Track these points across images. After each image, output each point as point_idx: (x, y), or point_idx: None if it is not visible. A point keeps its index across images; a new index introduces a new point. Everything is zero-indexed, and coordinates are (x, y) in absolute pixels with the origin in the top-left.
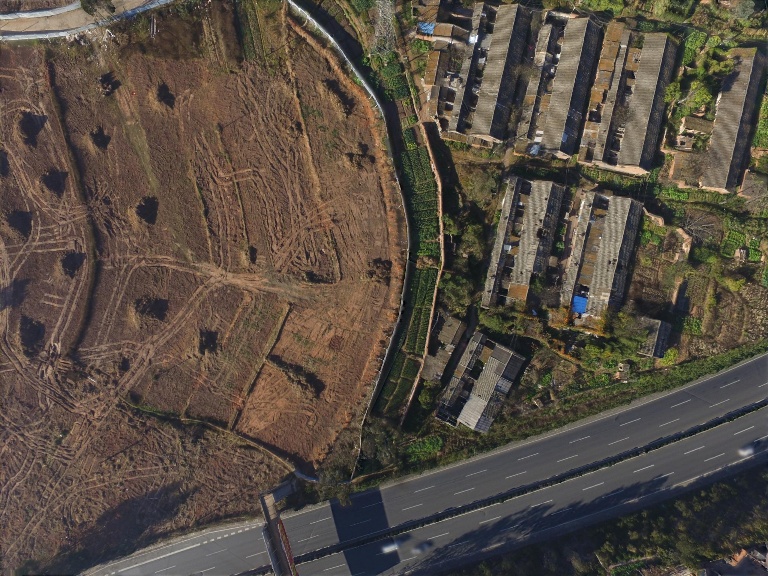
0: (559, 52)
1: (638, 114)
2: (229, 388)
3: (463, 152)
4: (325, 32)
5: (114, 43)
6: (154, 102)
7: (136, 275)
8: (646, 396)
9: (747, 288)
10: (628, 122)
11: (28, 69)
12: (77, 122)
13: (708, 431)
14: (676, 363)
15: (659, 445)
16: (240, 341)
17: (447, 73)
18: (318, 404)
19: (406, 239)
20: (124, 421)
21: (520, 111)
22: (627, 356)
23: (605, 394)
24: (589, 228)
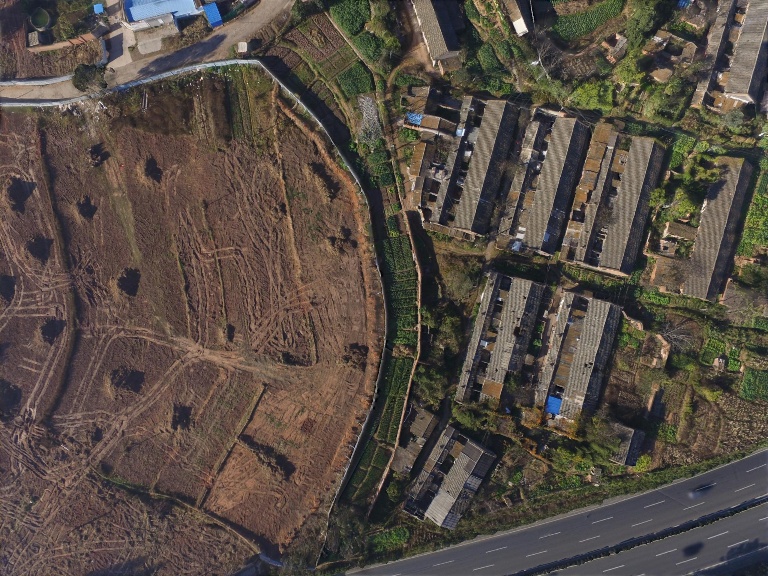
0: (546, 148)
1: (621, 217)
2: (200, 465)
3: (445, 243)
4: (314, 116)
5: (106, 115)
6: (141, 176)
7: (114, 345)
8: (619, 495)
9: (724, 399)
10: (611, 224)
11: (20, 136)
12: (65, 191)
13: (681, 534)
14: (649, 470)
15: (630, 546)
16: (213, 418)
17: (432, 164)
18: (287, 486)
19: (384, 326)
20: (94, 492)
21: (503, 207)
22: (598, 463)
23: (576, 494)
24: (567, 329)
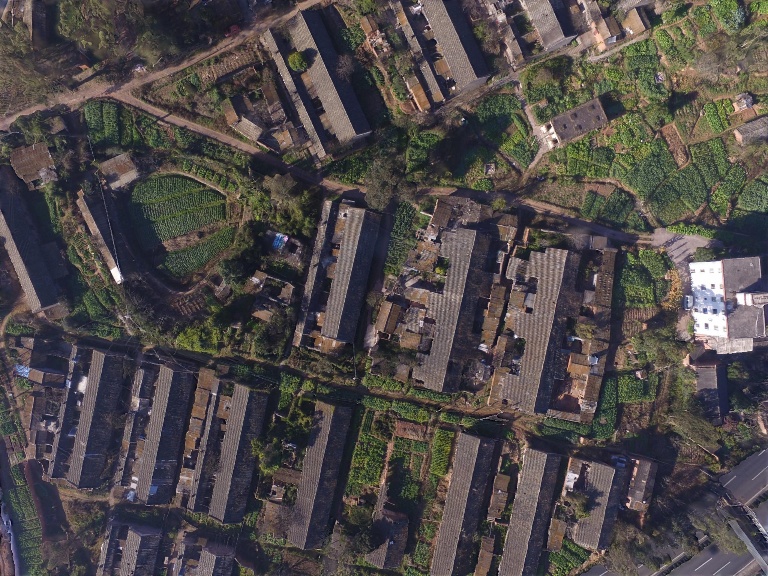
0: None
1: (225, 467)
2: None
3: (70, 490)
4: None
5: None
6: None
7: None
8: None
9: None
10: (218, 473)
11: None
12: None
13: None
14: None
15: None
16: None
17: (46, 415)
18: None
19: None
20: None
21: (115, 457)
22: None
23: None
24: None
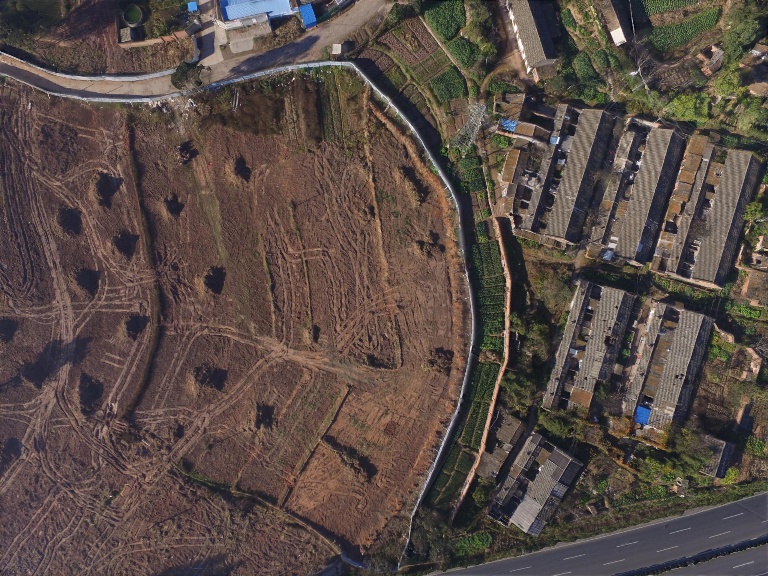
0: (639, 158)
1: (716, 230)
2: (281, 464)
3: (534, 250)
4: (406, 120)
5: (196, 113)
6: (230, 175)
7: (198, 343)
8: None
9: None
10: (705, 236)
11: (109, 131)
12: (152, 187)
13: (759, 546)
14: (736, 482)
15: (708, 557)
16: (296, 418)
17: (525, 171)
18: (369, 488)
19: (470, 331)
20: (175, 488)
21: (596, 216)
22: (689, 475)
23: (659, 504)
24: (658, 339)
